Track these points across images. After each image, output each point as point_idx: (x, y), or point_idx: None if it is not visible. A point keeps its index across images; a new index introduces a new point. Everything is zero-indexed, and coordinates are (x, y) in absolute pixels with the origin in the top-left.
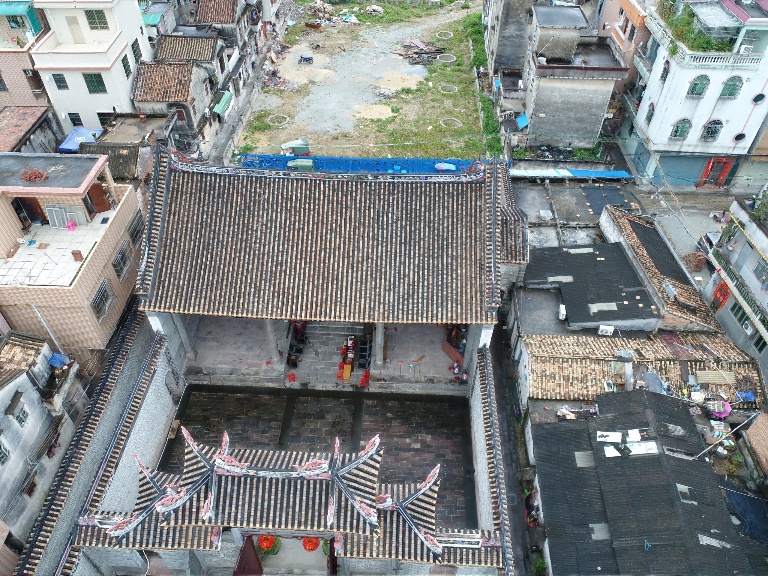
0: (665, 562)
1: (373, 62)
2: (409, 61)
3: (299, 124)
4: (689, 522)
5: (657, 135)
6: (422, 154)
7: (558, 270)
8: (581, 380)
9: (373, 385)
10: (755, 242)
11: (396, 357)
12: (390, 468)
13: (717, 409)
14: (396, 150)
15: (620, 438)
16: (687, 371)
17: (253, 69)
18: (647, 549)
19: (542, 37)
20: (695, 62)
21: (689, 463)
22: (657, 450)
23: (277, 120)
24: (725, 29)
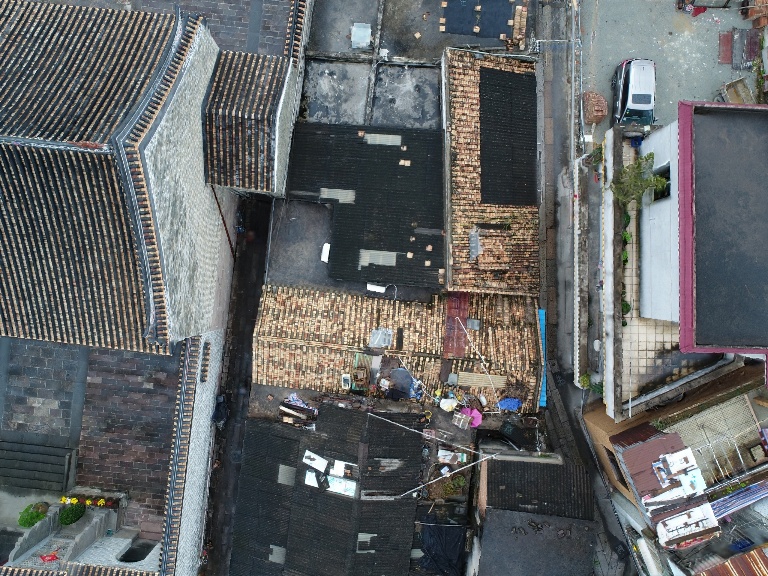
0: None
1: None
2: None
3: None
4: (355, 574)
5: None
6: None
7: (339, 176)
8: (315, 370)
9: None
10: (604, 218)
11: None
12: (117, 411)
13: (461, 426)
14: None
15: (324, 468)
16: (448, 371)
17: None
18: None
19: None
20: None
21: (388, 504)
22: (354, 494)
23: None
24: None
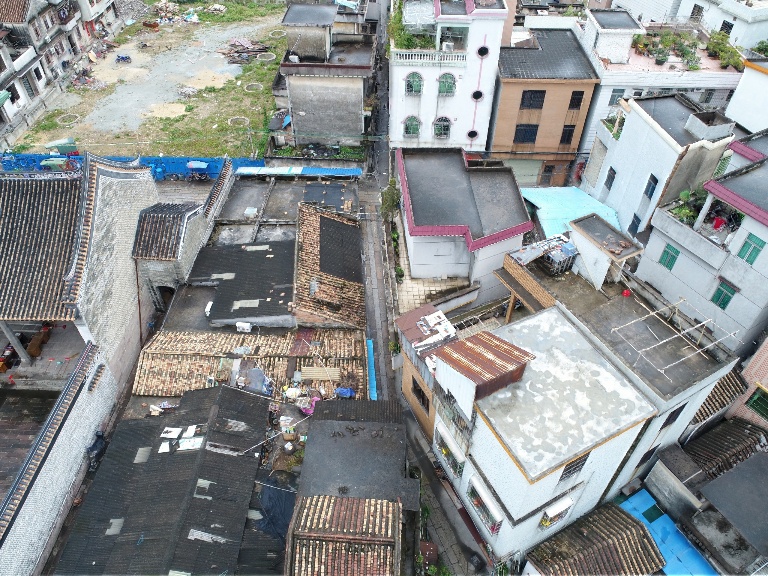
0: (145, 557)
1: (192, 61)
2: (228, 60)
3: (86, 123)
4: (189, 517)
5: (391, 133)
6: (194, 152)
7: (226, 267)
8: (186, 376)
9: (18, 382)
10: None
11: (50, 354)
12: None
13: (302, 405)
14: (169, 149)
15: (178, 434)
16: (293, 367)
17: (65, 68)
18: (138, 544)
19: (289, 35)
20: (402, 59)
21: (230, 458)
22: (200, 446)
23: (69, 119)
24: (422, 26)
